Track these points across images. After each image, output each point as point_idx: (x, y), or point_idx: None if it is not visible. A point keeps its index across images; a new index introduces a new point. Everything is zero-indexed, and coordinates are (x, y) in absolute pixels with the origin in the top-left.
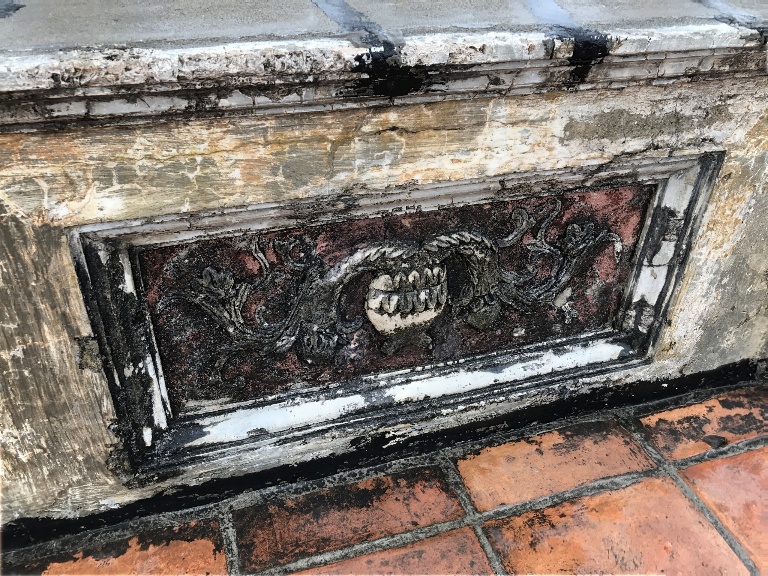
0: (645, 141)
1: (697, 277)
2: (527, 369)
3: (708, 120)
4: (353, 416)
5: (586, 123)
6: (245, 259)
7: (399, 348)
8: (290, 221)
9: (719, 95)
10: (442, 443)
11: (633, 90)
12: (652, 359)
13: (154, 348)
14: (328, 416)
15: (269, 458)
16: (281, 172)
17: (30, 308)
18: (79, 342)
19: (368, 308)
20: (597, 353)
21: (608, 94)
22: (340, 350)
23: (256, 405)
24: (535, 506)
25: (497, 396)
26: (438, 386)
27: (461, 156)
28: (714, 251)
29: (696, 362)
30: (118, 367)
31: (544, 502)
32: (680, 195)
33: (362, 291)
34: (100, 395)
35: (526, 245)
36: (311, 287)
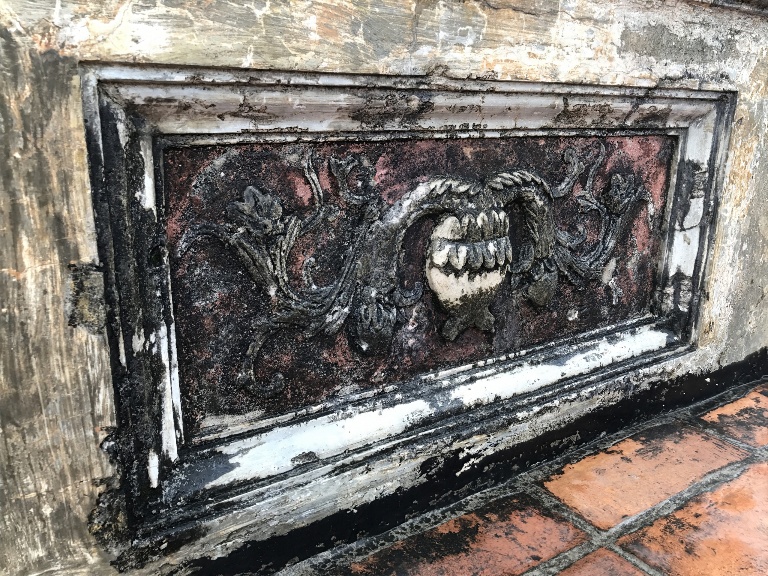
0: (681, 67)
1: (725, 240)
2: (589, 360)
3: (723, 54)
4: (419, 428)
5: (637, 35)
6: (295, 181)
7: (462, 330)
8: (354, 124)
9: (729, 28)
10: (517, 466)
11: (671, 4)
12: (696, 344)
13: (170, 314)
14: (391, 429)
15: (323, 499)
16: (361, 32)
17: (5, 201)
18: (75, 273)
19: (431, 267)
20: (646, 340)
21: (653, 4)
22: (398, 332)
23: (297, 420)
24: (661, 512)
25: (568, 393)
26: (506, 383)
27: (537, 50)
28: (735, 209)
29: (729, 350)
30: (124, 332)
31: (668, 506)
32: (701, 145)
33: (422, 245)
34: (95, 379)
35: (576, 198)
36: (370, 230)
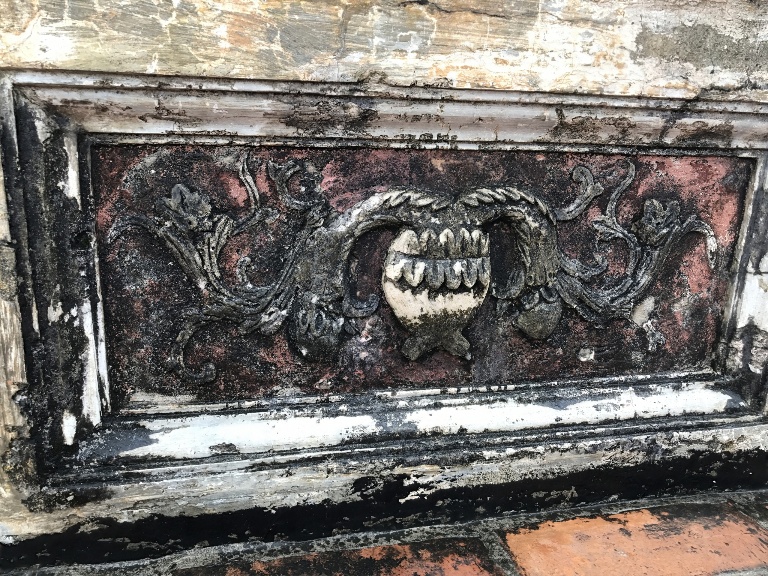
0: (739, 76)
1: None
2: (600, 409)
3: None
4: (359, 444)
5: (663, 37)
6: (229, 182)
7: (426, 351)
8: (289, 130)
9: None
10: (484, 509)
11: None
12: None
13: (96, 293)
14: (324, 439)
15: (236, 491)
16: (278, 39)
17: None
18: None
19: (386, 280)
20: (695, 400)
21: None
22: (346, 343)
23: (227, 412)
24: None
25: (560, 442)
26: (478, 417)
27: (507, 56)
28: None
29: None
30: (40, 303)
31: None
32: None
33: (379, 257)
34: (8, 339)
35: (592, 223)
36: (312, 236)
